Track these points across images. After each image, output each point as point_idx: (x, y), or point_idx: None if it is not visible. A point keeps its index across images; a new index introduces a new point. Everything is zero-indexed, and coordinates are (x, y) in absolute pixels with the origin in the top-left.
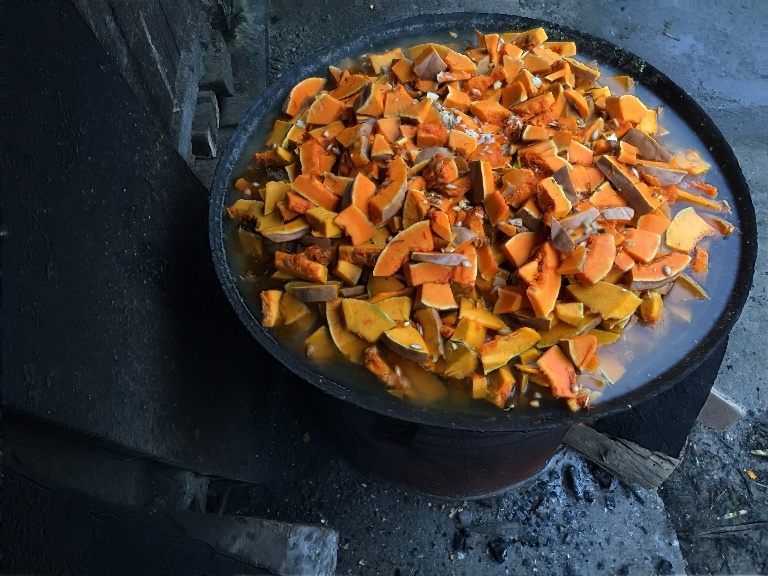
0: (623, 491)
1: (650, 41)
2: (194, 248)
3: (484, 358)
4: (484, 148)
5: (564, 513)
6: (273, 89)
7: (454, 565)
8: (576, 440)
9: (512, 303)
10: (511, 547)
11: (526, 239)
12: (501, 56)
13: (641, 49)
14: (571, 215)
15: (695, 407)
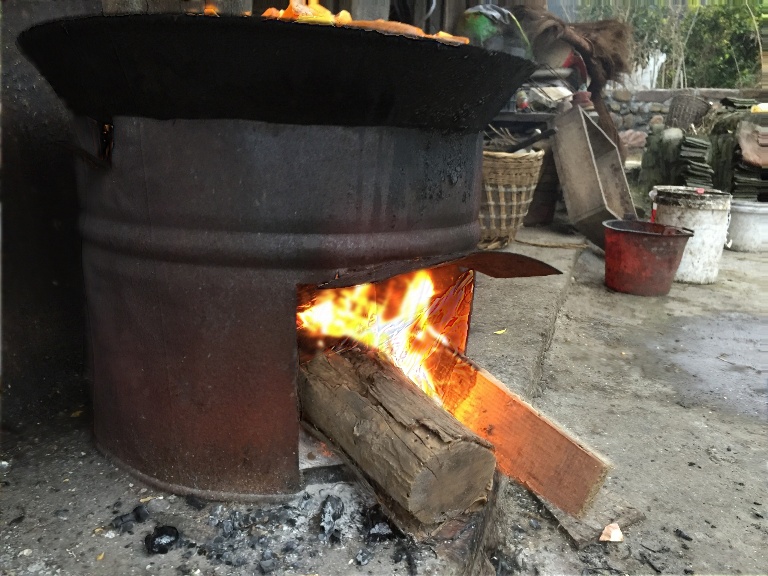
0: (395, 553)
1: (699, 358)
2: None
3: None
4: None
5: (287, 542)
6: None
7: (91, 538)
8: (335, 411)
9: None
10: (182, 549)
11: None
12: None
13: (686, 360)
14: None
15: None
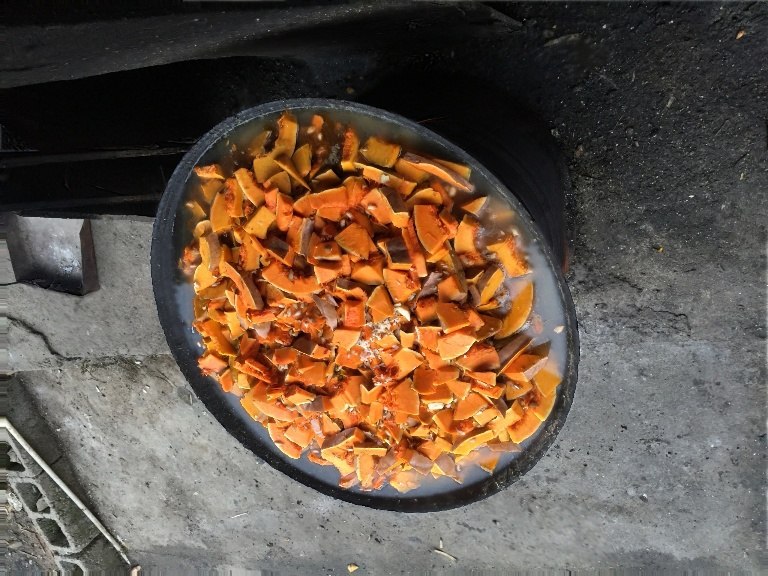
0: None
1: None
2: None
3: None
4: (356, 351)
5: None
6: (438, 138)
7: None
8: None
9: (241, 347)
10: None
11: None
12: (474, 381)
13: None
14: None
15: None
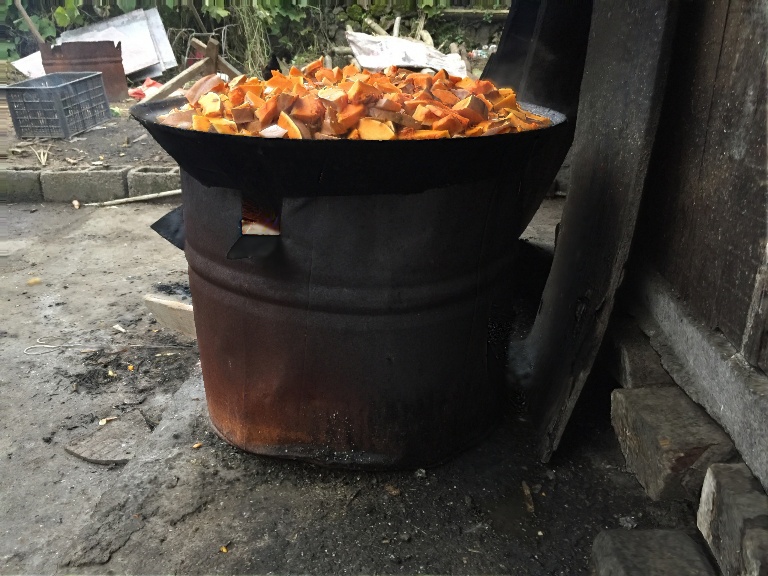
0: None
1: None
2: None
3: None
4: None
5: None
6: None
7: None
8: None
9: None
10: None
11: None
12: None
13: None
14: None
15: None
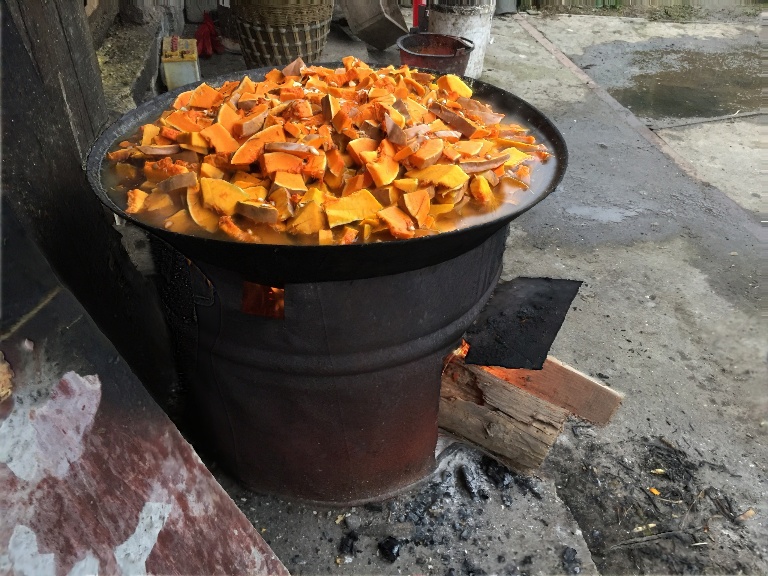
0: (519, 489)
1: None
2: (79, 232)
3: (328, 210)
4: None
5: (459, 511)
6: (164, 96)
7: (340, 569)
8: (459, 418)
9: (356, 182)
10: (404, 547)
11: (368, 144)
12: None
13: None
14: (406, 129)
15: (552, 330)
